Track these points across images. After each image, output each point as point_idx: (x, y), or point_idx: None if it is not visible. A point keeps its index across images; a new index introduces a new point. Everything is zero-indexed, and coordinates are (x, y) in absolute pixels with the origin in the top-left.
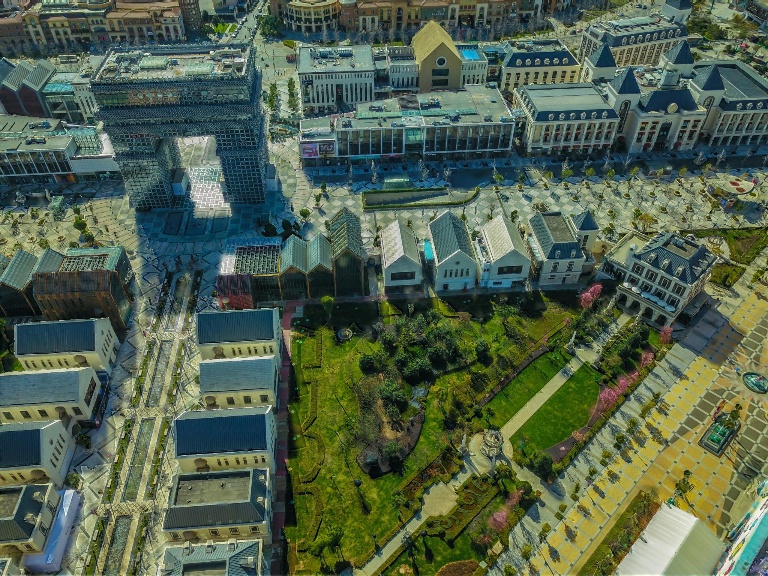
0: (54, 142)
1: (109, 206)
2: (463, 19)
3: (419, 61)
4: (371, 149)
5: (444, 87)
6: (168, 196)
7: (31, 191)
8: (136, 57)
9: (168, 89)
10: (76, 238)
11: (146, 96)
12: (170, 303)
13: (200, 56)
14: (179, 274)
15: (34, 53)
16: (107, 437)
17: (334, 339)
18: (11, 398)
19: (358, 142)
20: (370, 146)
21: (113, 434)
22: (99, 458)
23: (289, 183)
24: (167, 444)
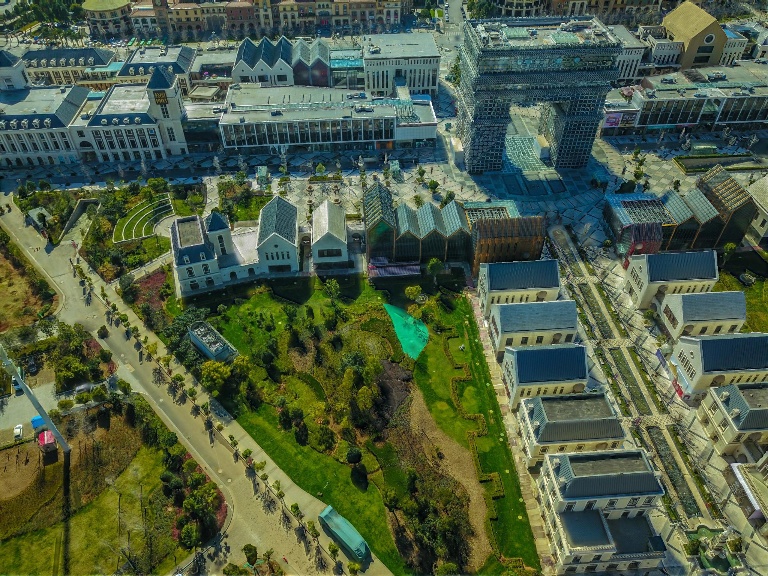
0: (381, 111)
1: (440, 170)
2: (662, 4)
3: (686, 39)
4: (669, 119)
5: (705, 64)
6: (501, 160)
7: (361, 156)
8: (496, 28)
9: (548, 56)
10: (430, 197)
11: (524, 62)
12: (561, 252)
13: (550, 27)
14: (551, 228)
15: (271, 35)
16: (587, 363)
17: (739, 283)
18: (518, 325)
19: (660, 112)
20: (669, 116)
21: (591, 361)
22: (593, 380)
23: (596, 150)
24: (647, 369)
